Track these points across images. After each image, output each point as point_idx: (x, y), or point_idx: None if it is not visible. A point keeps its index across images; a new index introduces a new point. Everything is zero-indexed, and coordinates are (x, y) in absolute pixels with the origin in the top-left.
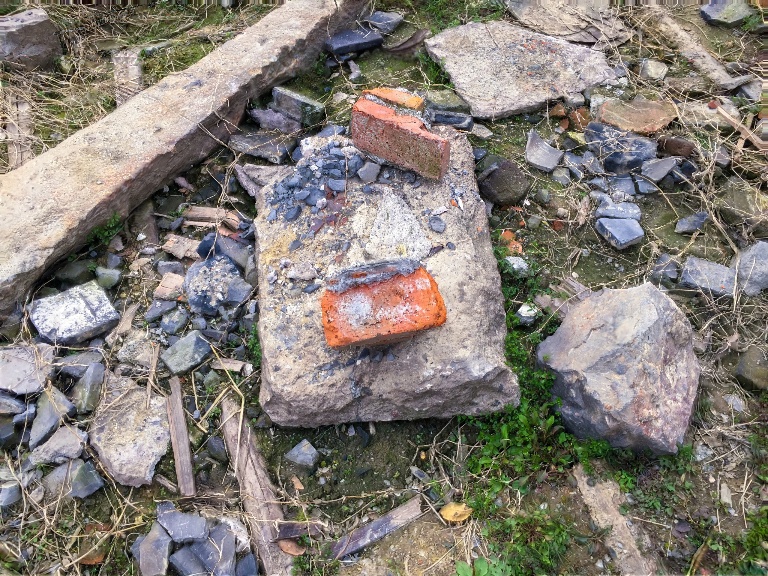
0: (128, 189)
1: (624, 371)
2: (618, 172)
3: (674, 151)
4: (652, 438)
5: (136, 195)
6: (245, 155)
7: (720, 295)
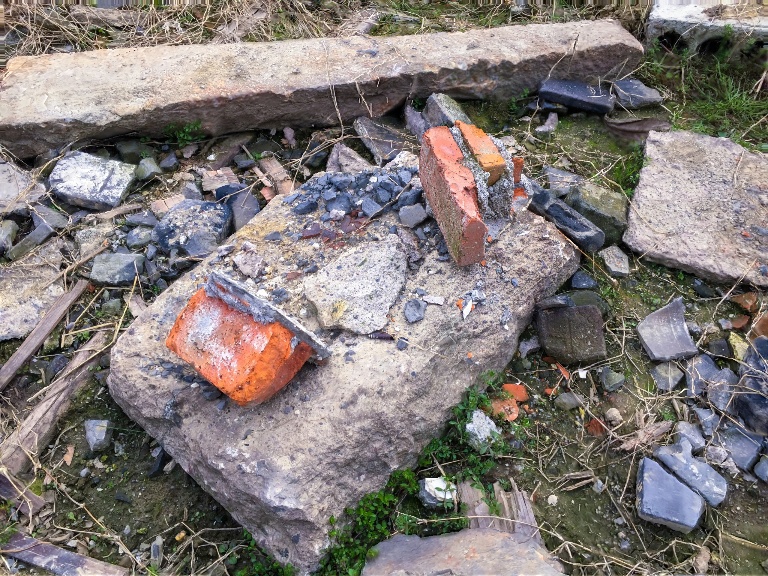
0: (221, 106)
1: None
2: (749, 425)
3: None
4: None
5: (231, 118)
6: (360, 141)
7: None
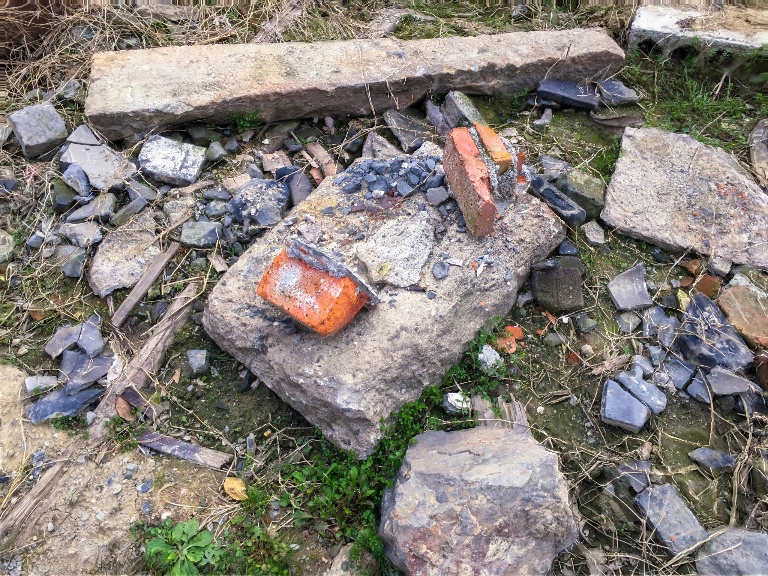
0: (276, 99)
1: (442, 500)
2: (687, 358)
3: (763, 379)
4: None
5: (283, 109)
6: (389, 130)
7: (661, 543)
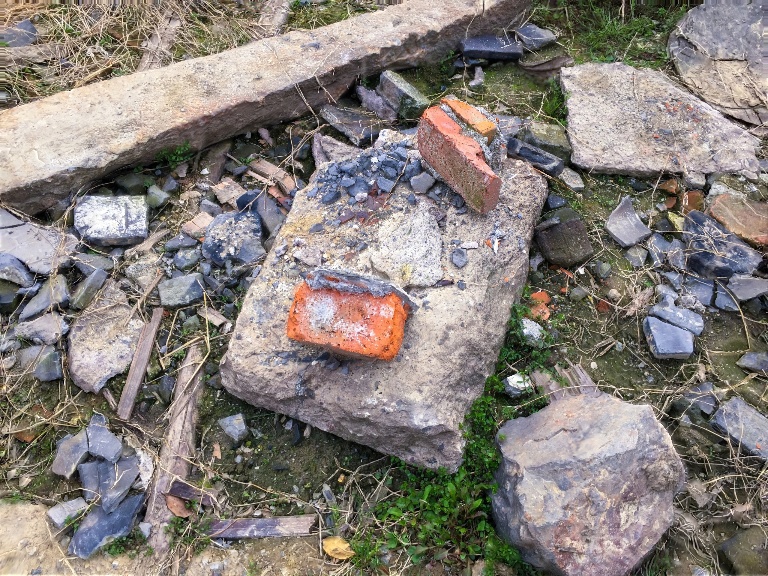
0: (205, 124)
1: (566, 487)
2: (702, 274)
3: None
4: (566, 571)
5: (214, 132)
6: (331, 127)
7: (750, 454)
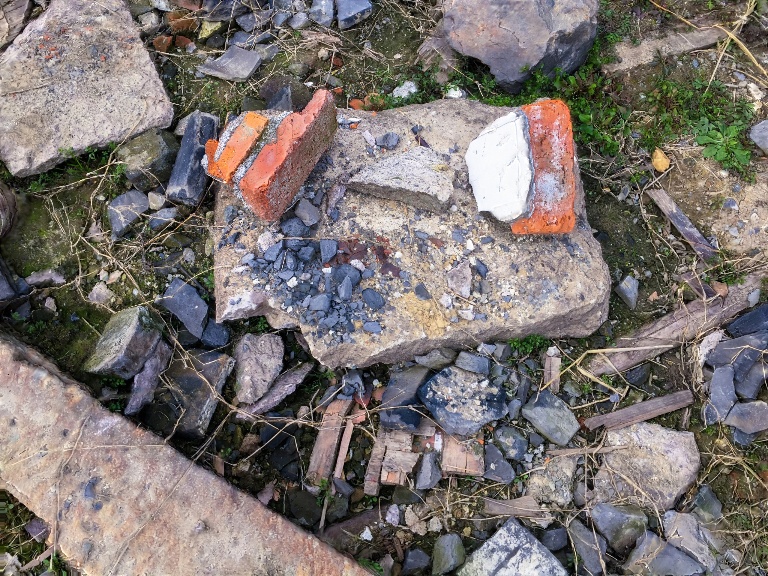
0: None
1: (551, 1)
2: (265, 1)
3: None
4: None
5: None
6: (218, 409)
7: None
